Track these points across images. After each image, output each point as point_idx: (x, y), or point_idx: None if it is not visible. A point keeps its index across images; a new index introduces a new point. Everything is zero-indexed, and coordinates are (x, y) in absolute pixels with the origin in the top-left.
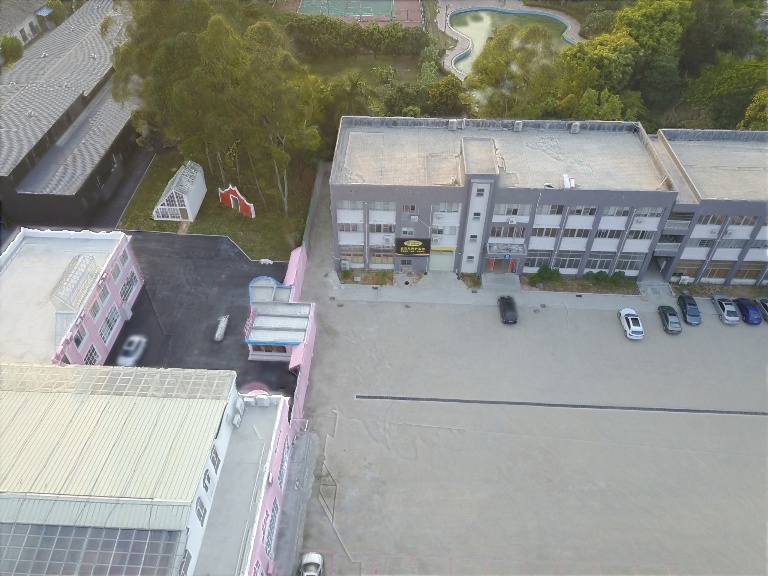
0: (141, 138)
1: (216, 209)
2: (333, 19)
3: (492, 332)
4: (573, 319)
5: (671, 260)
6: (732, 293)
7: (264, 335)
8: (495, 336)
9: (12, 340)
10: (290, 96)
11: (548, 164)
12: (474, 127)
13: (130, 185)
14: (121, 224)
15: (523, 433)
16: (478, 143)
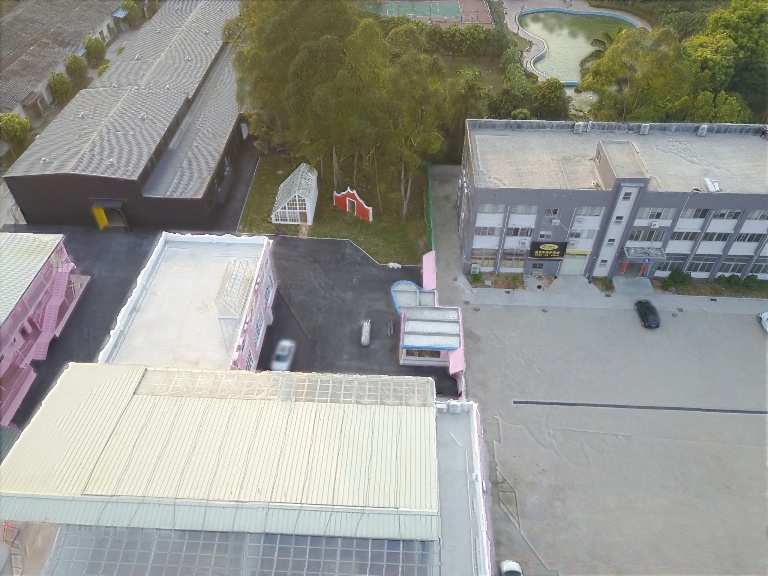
0: (259, 141)
1: (331, 212)
2: (414, 21)
3: (635, 336)
4: (714, 323)
5: None
6: None
7: (418, 340)
8: (639, 340)
9: (182, 346)
10: (437, 99)
11: (684, 167)
12: (599, 130)
13: (241, 188)
14: (241, 227)
15: (689, 439)
16: (617, 146)
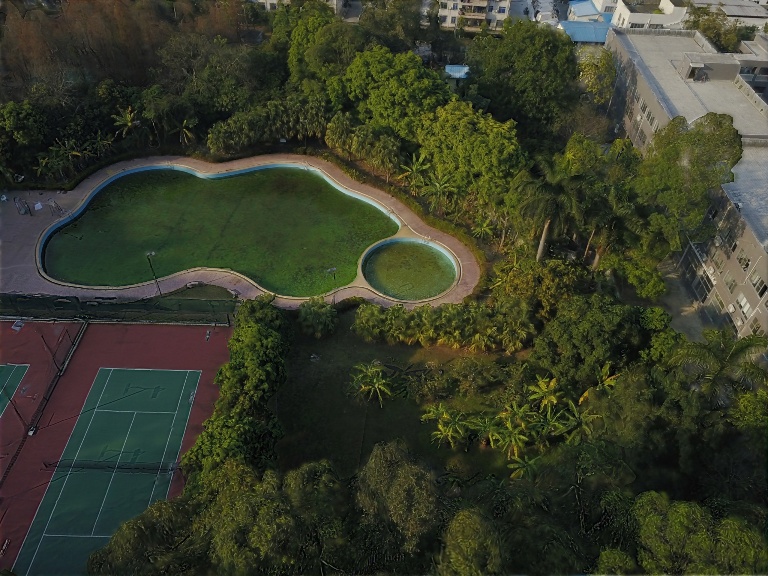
0: None
1: None
2: None
3: None
4: None
5: None
6: None
7: None
8: None
9: None
10: None
11: None
12: None
13: None
14: None
15: None
16: None
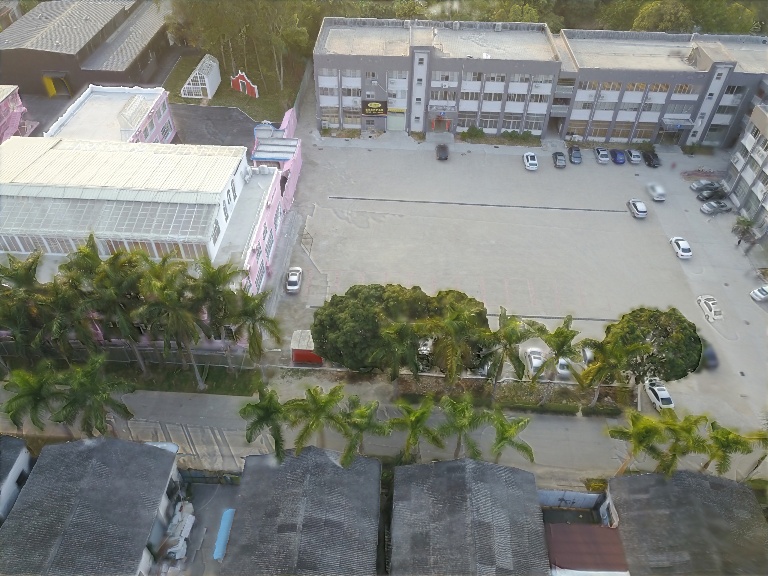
0: (172, 35)
1: (228, 92)
2: None
3: (430, 165)
4: (489, 159)
5: (564, 121)
6: (609, 147)
7: (265, 155)
8: (431, 168)
9: None
10: None
11: (474, 48)
12: None
13: (162, 75)
14: None
15: (443, 217)
16: (422, 30)
